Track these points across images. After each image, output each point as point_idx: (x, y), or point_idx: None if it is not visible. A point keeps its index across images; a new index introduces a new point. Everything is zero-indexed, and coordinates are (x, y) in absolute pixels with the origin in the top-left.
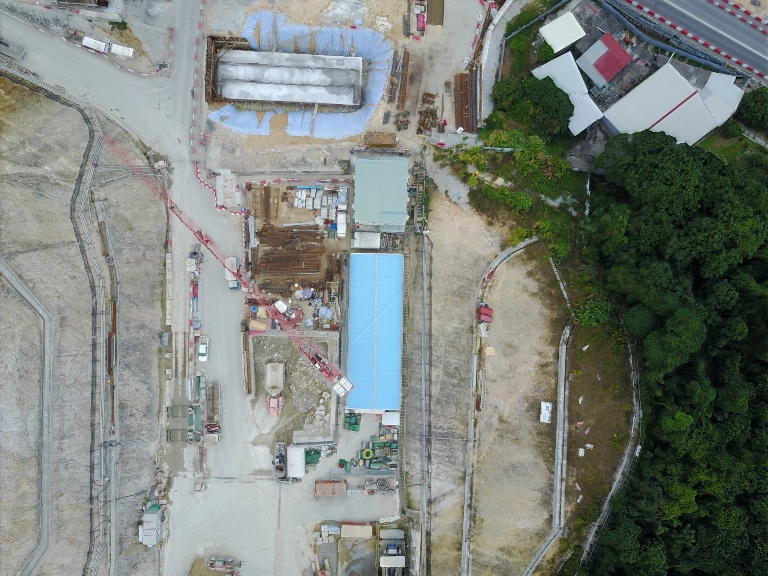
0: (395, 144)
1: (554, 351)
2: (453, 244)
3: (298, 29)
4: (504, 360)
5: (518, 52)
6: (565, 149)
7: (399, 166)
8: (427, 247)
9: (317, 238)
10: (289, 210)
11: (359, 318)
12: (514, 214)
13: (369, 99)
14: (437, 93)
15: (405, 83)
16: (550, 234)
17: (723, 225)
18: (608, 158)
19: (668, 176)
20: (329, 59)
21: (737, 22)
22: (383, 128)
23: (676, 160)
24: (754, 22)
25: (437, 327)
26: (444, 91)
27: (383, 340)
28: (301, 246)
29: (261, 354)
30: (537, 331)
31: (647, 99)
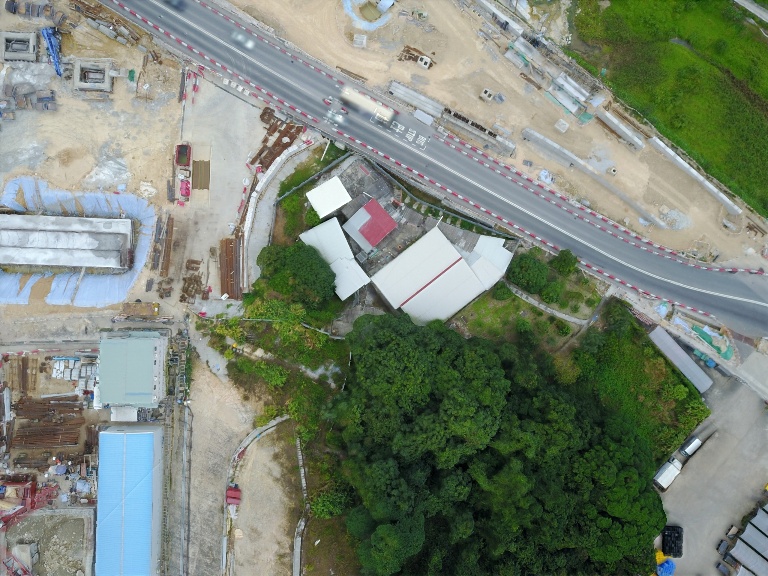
0: (158, 312)
1: (290, 542)
2: (210, 418)
3: (60, 195)
4: (250, 544)
5: (291, 212)
6: (337, 311)
7: (145, 346)
8: (188, 418)
9: (76, 410)
10: (48, 381)
11: (107, 499)
12: (270, 388)
13: (135, 264)
14: (202, 259)
15: (169, 249)
16: (298, 414)
17: (443, 425)
18: (351, 341)
19: (389, 375)
20: (96, 222)
21: (508, 183)
22: (146, 295)
23: (402, 355)
24: (525, 183)
25: (194, 502)
26: (209, 257)
27: (131, 522)
28: (58, 419)
29: (12, 533)
30: (277, 519)
31: (414, 264)
